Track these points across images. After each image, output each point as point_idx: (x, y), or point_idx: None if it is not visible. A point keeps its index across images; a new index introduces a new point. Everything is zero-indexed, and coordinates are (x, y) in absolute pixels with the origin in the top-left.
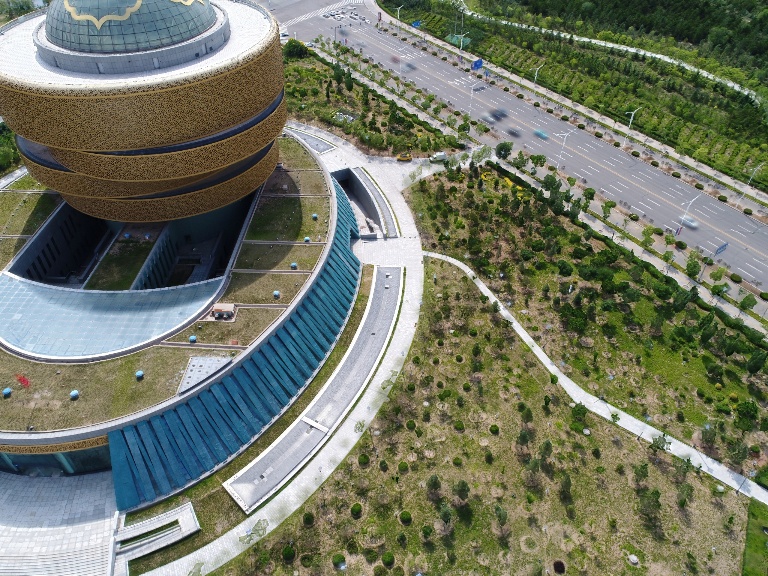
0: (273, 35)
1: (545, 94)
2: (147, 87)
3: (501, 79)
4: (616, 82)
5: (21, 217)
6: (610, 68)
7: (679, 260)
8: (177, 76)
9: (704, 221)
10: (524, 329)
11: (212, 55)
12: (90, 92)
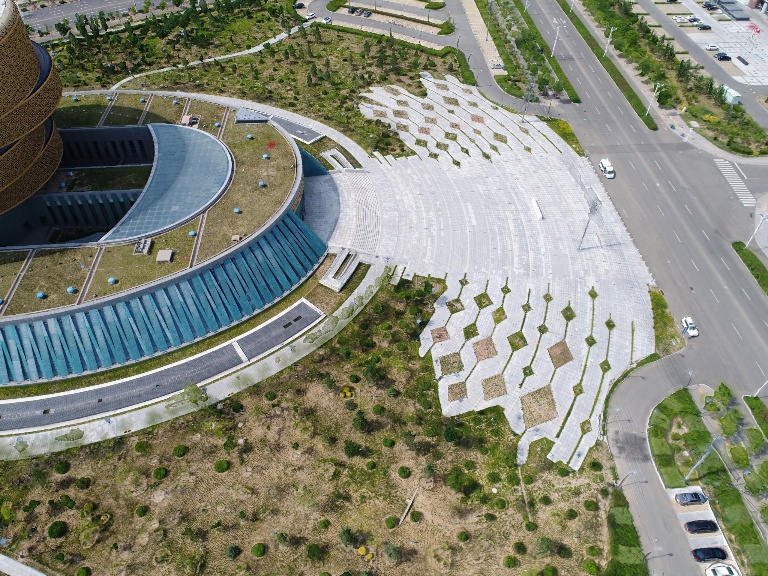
0: None
1: None
2: None
3: None
4: None
5: None
6: None
7: (155, 14)
8: None
9: (120, 3)
10: None
11: None
12: (8, 25)
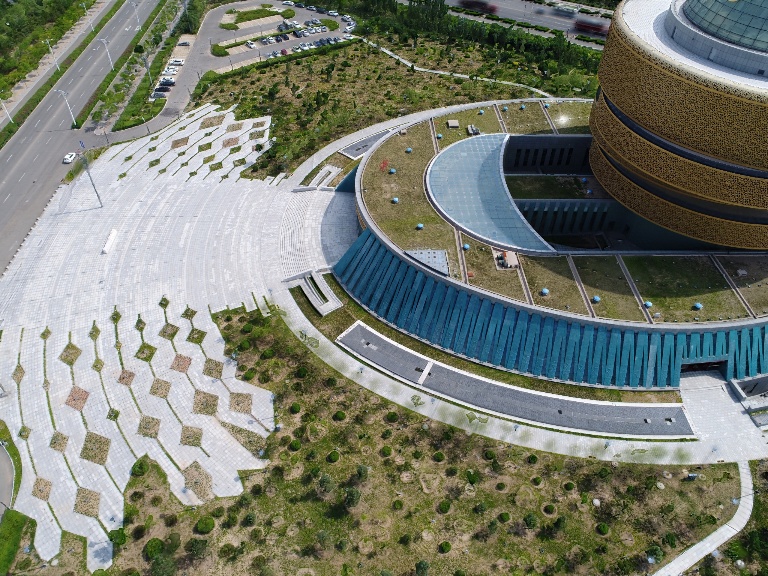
0: None
1: None
2: (661, 62)
3: None
4: None
5: (580, 122)
6: None
7: None
8: (694, 69)
9: None
10: None
11: None
12: (629, 41)
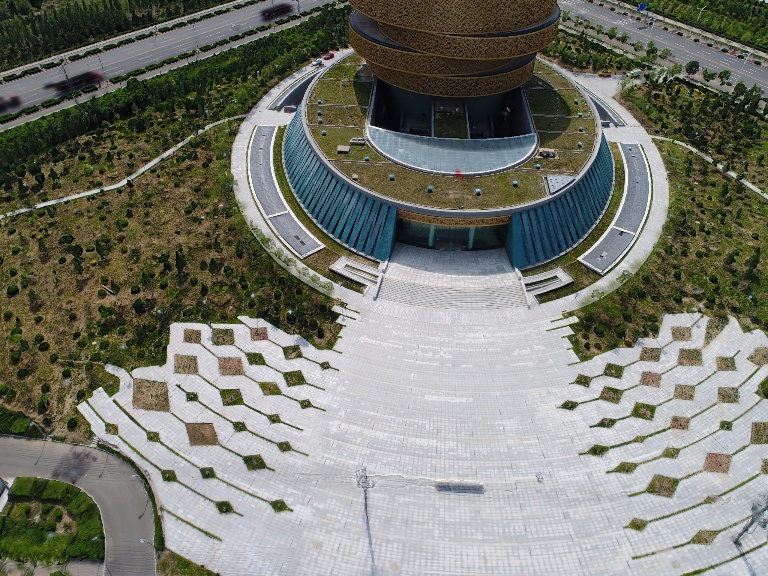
0: None
1: (700, 33)
2: None
3: None
4: (763, 24)
5: (350, 95)
6: None
7: None
8: None
9: None
10: (750, 183)
11: None
12: None
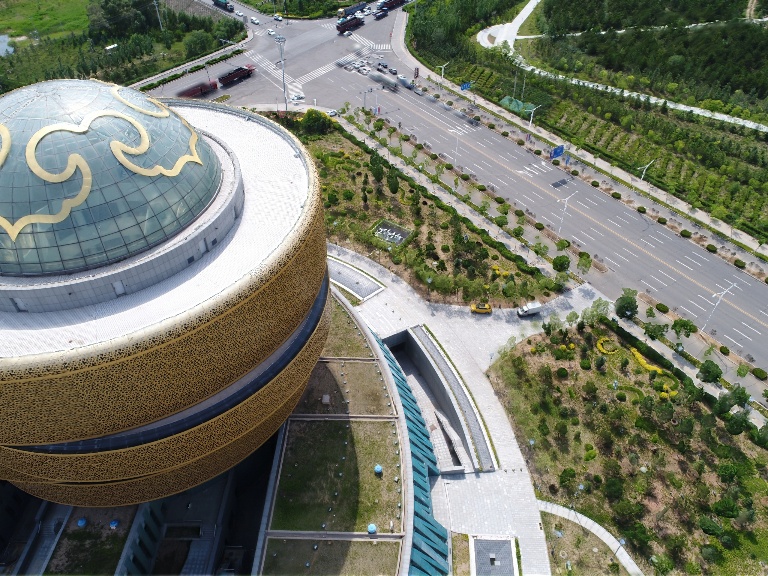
0: (314, 203)
1: (648, 192)
2: (99, 358)
3: (584, 166)
4: (745, 178)
5: None
6: (726, 152)
7: None
8: (155, 328)
9: None
10: None
11: (216, 255)
12: None
